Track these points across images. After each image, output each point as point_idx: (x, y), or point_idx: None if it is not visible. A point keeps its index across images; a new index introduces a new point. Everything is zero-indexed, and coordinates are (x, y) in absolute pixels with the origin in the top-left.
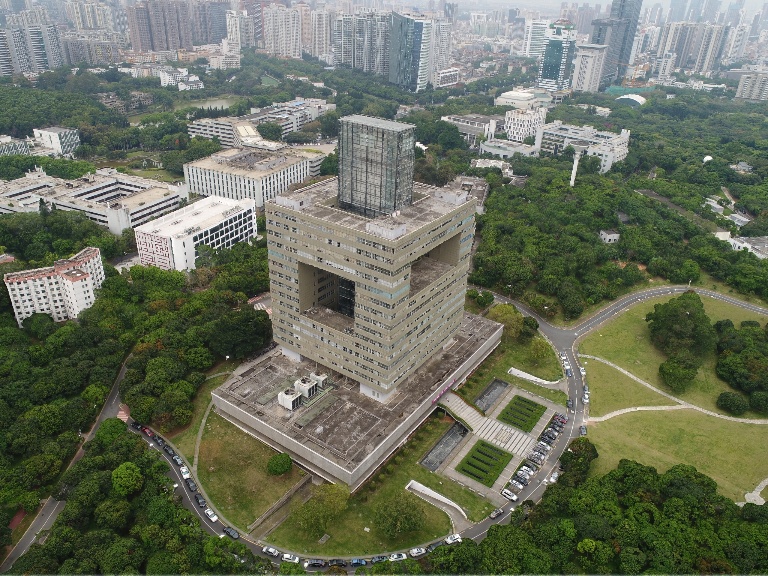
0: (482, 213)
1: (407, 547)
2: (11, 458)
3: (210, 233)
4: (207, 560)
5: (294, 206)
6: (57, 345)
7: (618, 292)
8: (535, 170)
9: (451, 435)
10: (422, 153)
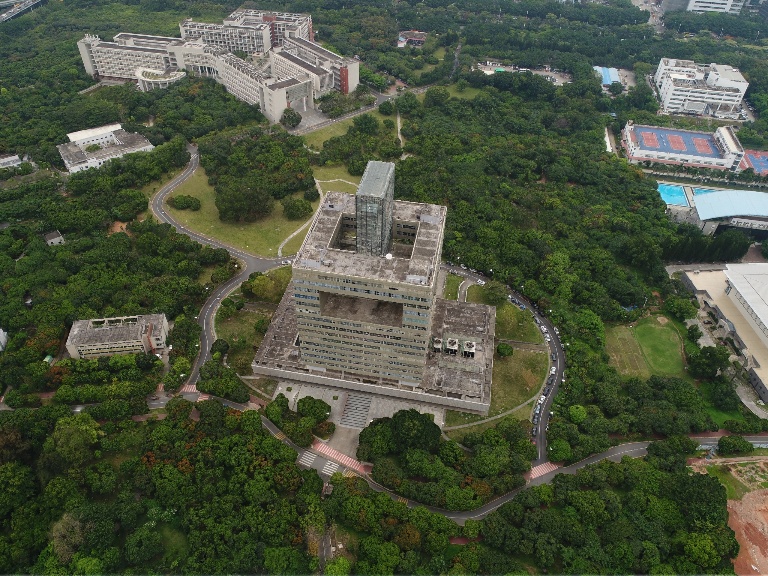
0: (4, 335)
1: None
2: (624, 498)
3: None
4: None
5: None
6: None
7: None
8: None
9: None
10: None
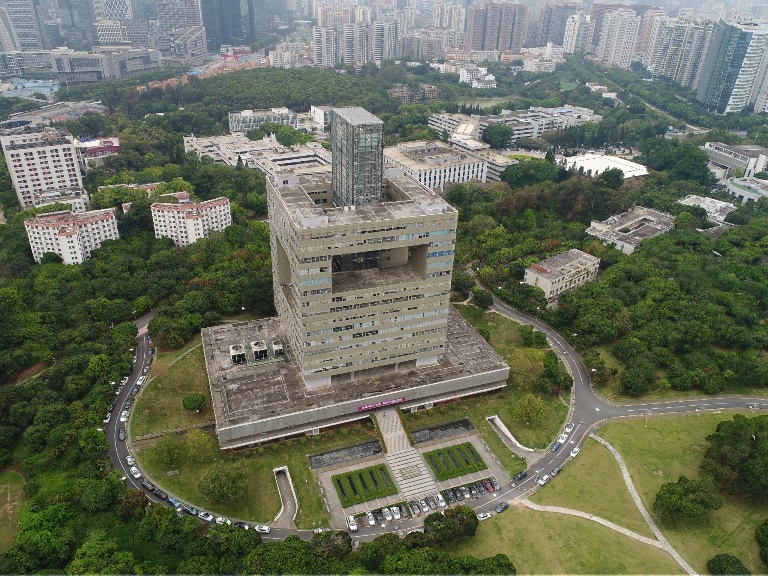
0: None
1: (222, 513)
2: (63, 326)
3: None
4: (79, 441)
5: (278, 183)
6: (153, 262)
7: (722, 387)
8: (753, 220)
9: (364, 448)
10: (620, 176)
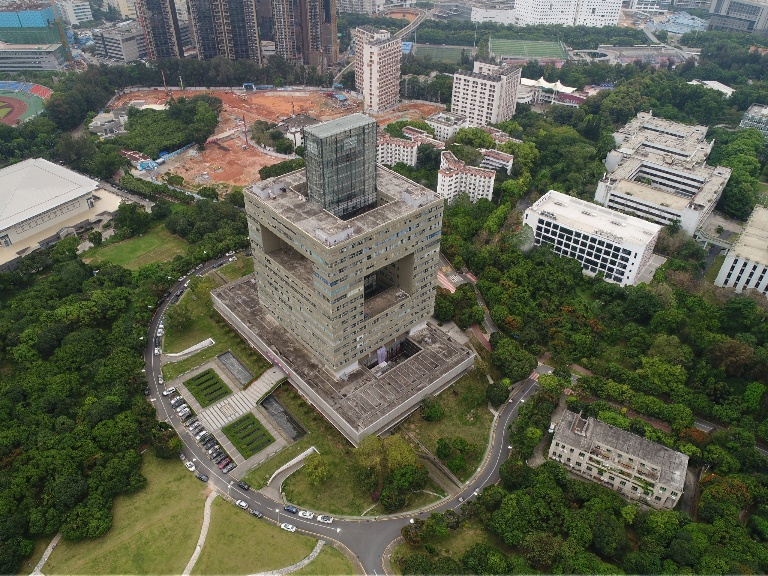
0: None
1: None
2: None
3: (561, 230)
4: None
5: None
6: None
7: None
8: None
9: (249, 377)
10: None
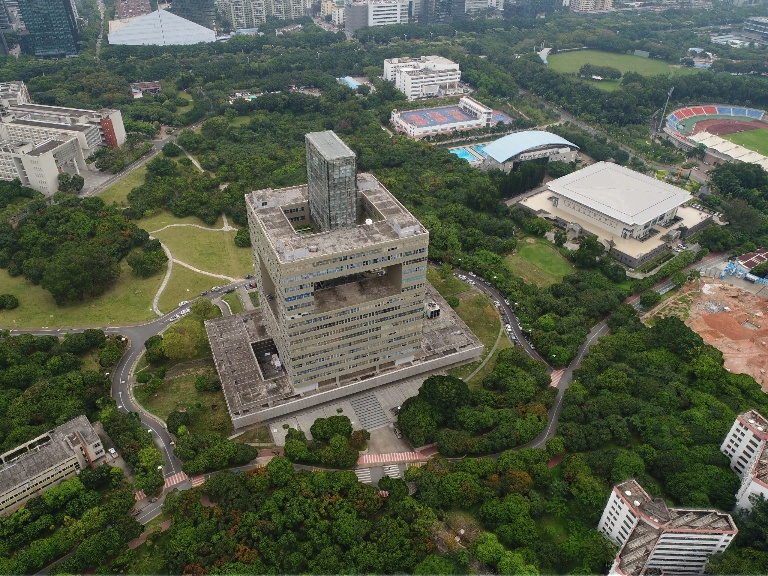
0: None
1: None
2: None
3: None
4: None
5: None
6: None
7: None
8: None
9: None
10: None
